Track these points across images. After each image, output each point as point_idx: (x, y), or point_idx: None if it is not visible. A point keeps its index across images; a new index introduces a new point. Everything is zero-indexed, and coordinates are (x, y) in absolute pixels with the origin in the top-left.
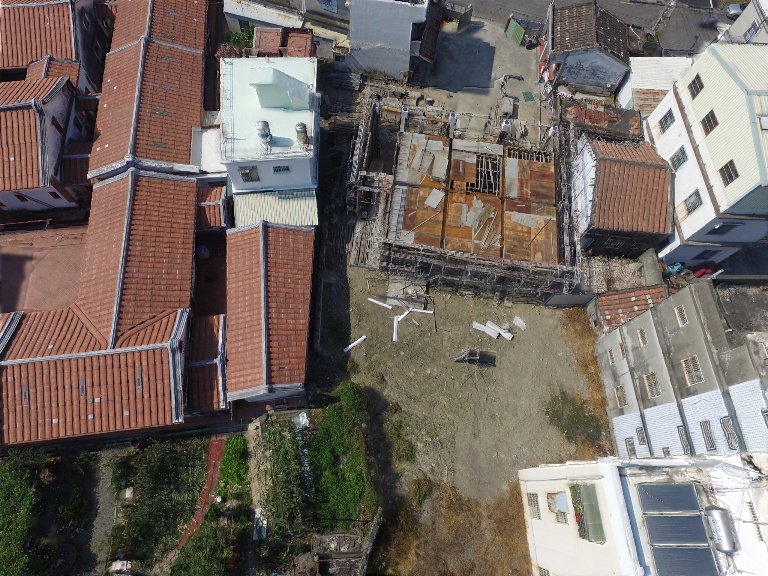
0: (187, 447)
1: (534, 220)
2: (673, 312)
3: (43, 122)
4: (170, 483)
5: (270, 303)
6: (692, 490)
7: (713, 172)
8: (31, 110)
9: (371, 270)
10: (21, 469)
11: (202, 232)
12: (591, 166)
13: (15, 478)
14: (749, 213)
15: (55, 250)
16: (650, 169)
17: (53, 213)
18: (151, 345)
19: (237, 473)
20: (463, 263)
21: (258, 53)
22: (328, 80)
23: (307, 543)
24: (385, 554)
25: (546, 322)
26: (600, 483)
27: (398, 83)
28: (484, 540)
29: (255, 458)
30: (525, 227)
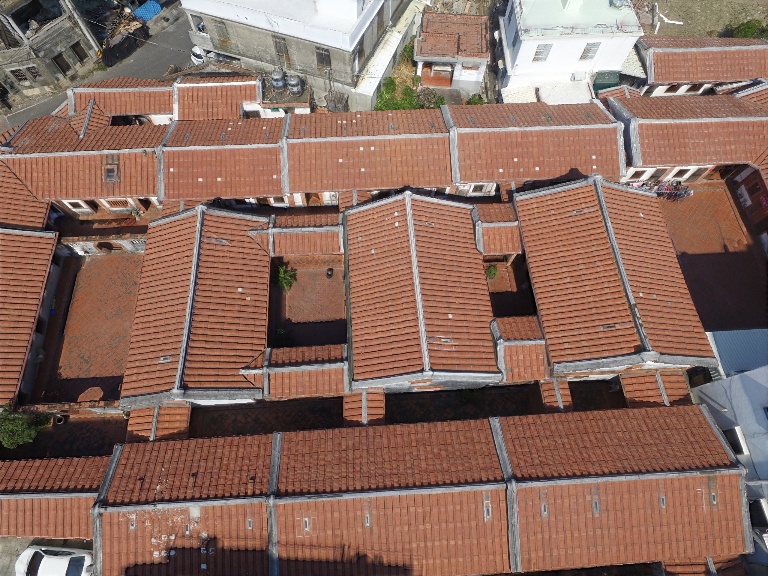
0: None
1: None
2: None
3: None
4: None
5: None
6: None
7: None
8: None
9: None
10: None
11: None
12: None
13: None
14: None
15: None
16: None
17: None
18: None
19: None
20: None
21: (460, 50)
22: None
23: None
24: None
25: None
26: None
27: (435, 0)
28: None
29: None
30: None
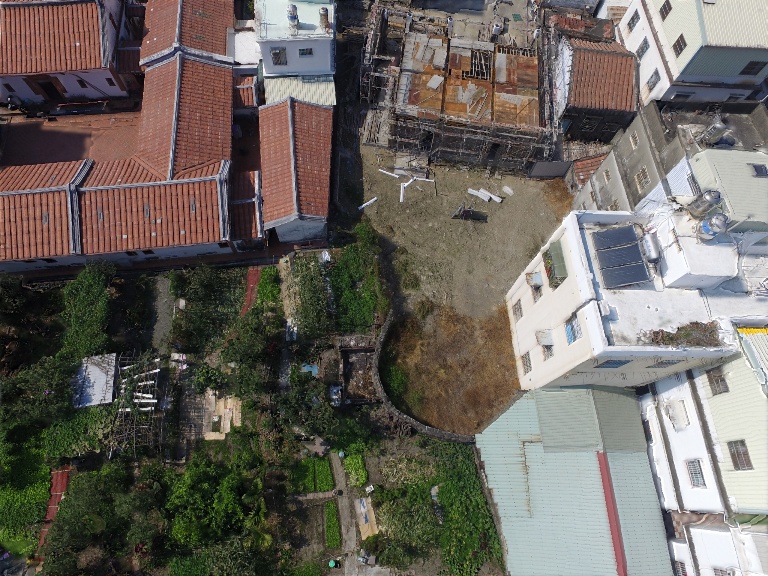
0: (229, 275)
1: (520, 99)
2: (629, 141)
3: (104, 14)
4: (216, 300)
5: (298, 157)
6: (632, 229)
7: (668, 49)
8: (94, 4)
9: (381, 148)
10: (98, 272)
11: (236, 116)
12: (568, 56)
13: (94, 278)
14: (697, 81)
15: (110, 130)
16: (618, 57)
17: (107, 102)
18: (203, 177)
19: (271, 293)
20: (459, 132)
21: None
22: (341, 1)
23: (330, 343)
24: (395, 346)
25: (530, 190)
26: (564, 235)
27: (403, 5)
28: (477, 345)
29: (286, 283)
30: (512, 104)
